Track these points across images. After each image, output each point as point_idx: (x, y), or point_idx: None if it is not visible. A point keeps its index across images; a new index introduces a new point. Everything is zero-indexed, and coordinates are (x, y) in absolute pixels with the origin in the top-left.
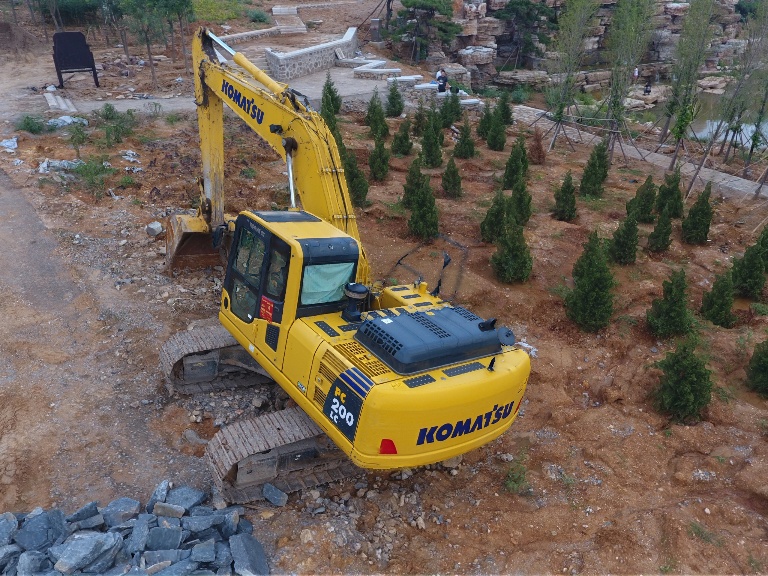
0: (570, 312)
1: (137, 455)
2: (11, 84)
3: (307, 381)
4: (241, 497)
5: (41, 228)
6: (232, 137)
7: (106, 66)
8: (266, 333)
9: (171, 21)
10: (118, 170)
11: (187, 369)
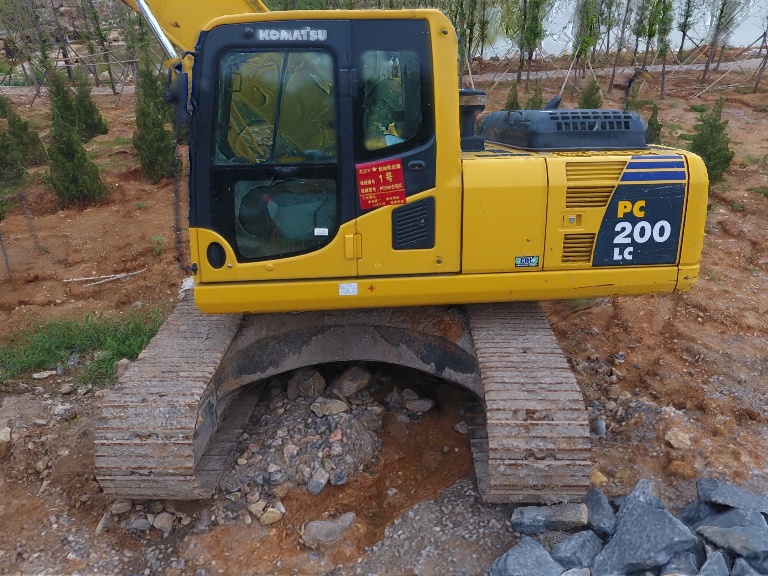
0: None
1: None
2: None
3: (543, 240)
4: None
5: None
6: None
7: None
8: (394, 230)
9: None
10: None
11: None
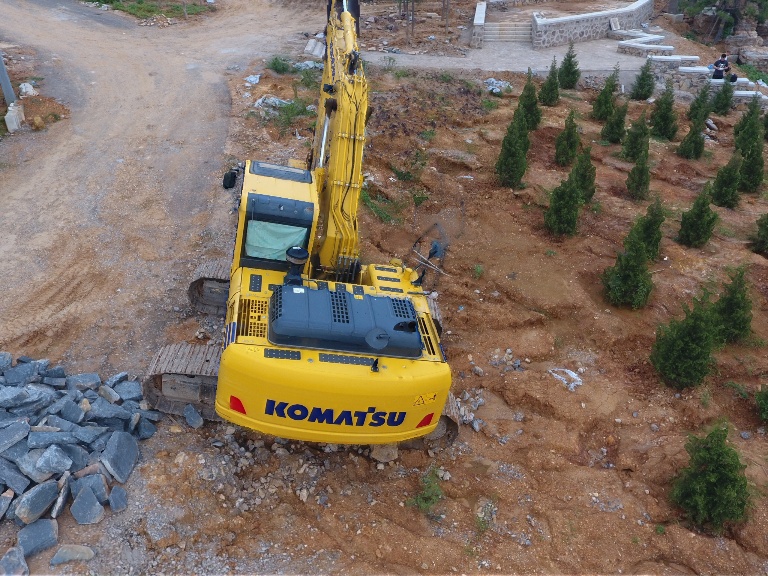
0: (653, 356)
1: (138, 347)
2: (293, 29)
3: None
4: (167, 407)
5: (220, 152)
6: (443, 98)
7: (378, 19)
8: None
9: None
10: (315, 114)
11: (206, 291)
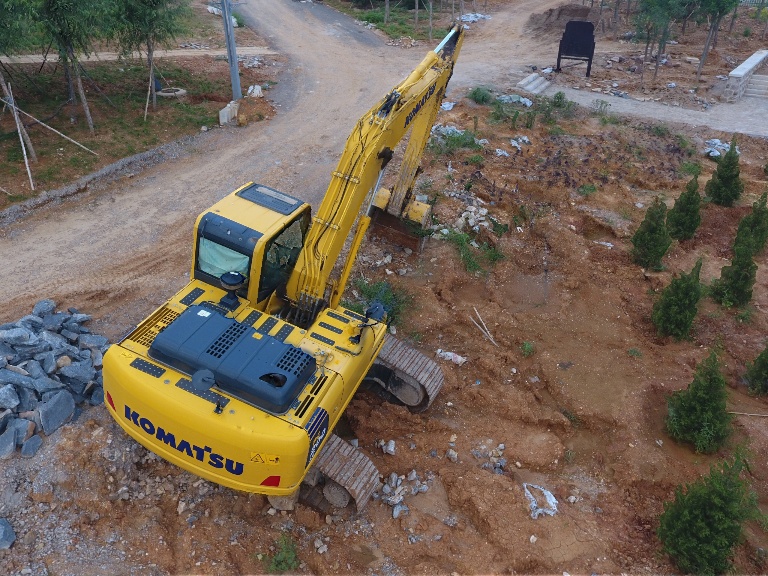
0: (663, 516)
1: None
2: (526, 61)
3: None
4: None
5: None
6: (640, 153)
7: (624, 59)
8: None
9: (700, 22)
10: (481, 148)
11: None
